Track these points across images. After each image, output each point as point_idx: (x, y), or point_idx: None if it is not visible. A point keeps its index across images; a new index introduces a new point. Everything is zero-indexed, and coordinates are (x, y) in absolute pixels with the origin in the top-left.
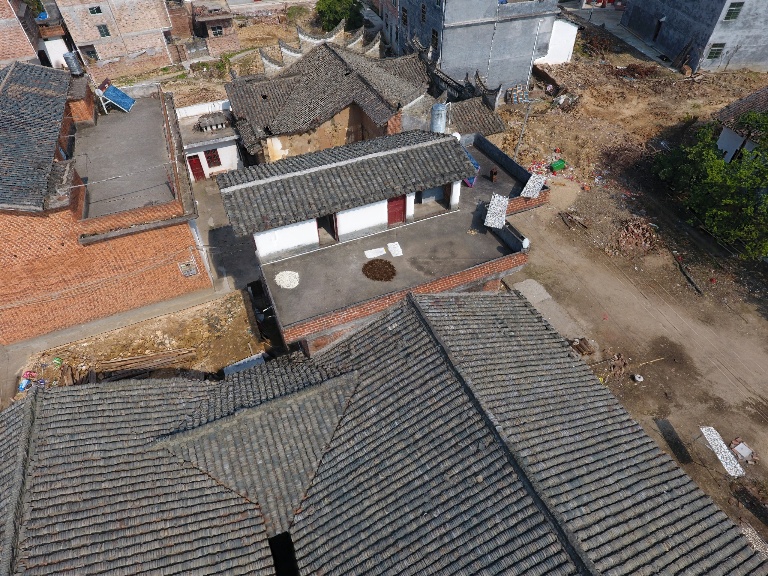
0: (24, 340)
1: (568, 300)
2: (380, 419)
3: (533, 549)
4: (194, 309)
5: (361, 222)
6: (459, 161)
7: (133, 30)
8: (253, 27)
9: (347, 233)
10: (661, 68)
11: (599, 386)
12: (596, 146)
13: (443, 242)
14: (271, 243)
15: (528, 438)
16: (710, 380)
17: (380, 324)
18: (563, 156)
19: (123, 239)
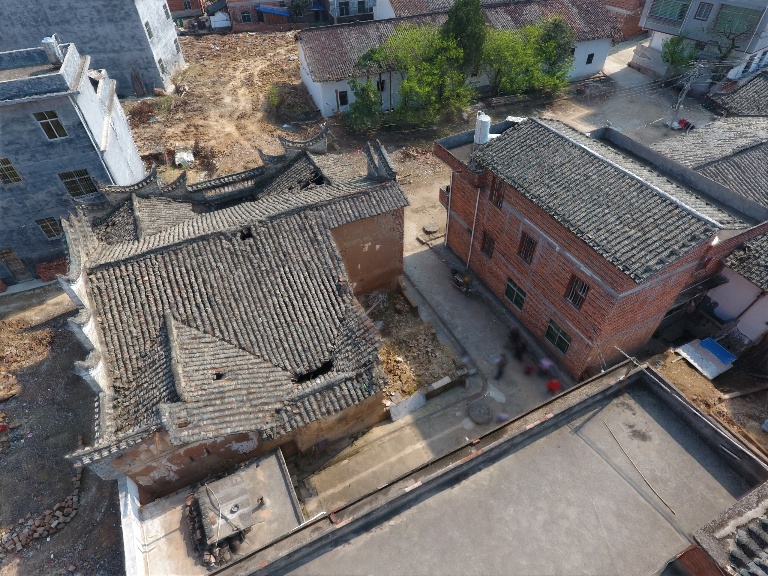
0: None
1: None
2: None
3: None
4: None
5: None
6: None
7: None
8: None
9: None
10: (149, 100)
11: None
12: None
13: None
14: None
15: None
16: None
17: None
18: None
19: None
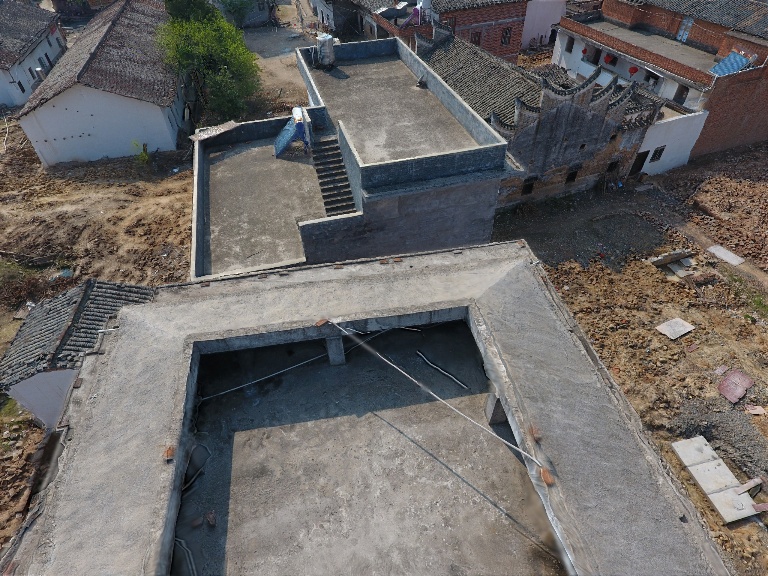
0: None
1: None
2: None
3: None
4: None
5: None
6: None
7: None
8: None
9: None
10: None
11: None
12: None
13: None
14: None
15: None
16: None
17: None
18: None
19: None
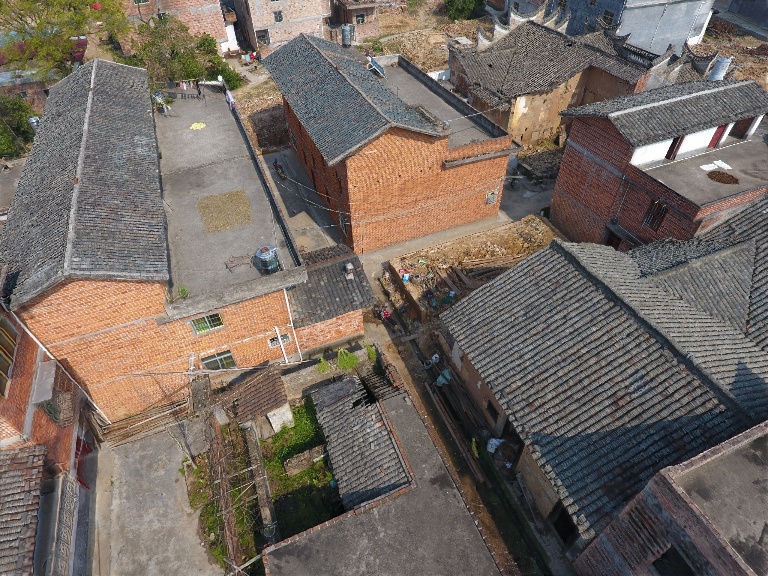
0: (368, 252)
1: None
2: None
3: None
4: (501, 229)
5: (694, 144)
6: (765, 98)
7: (299, 16)
8: (384, 16)
9: (682, 153)
10: None
11: None
12: None
13: (757, 160)
14: (640, 157)
15: None
16: None
17: (751, 210)
18: None
19: (466, 167)
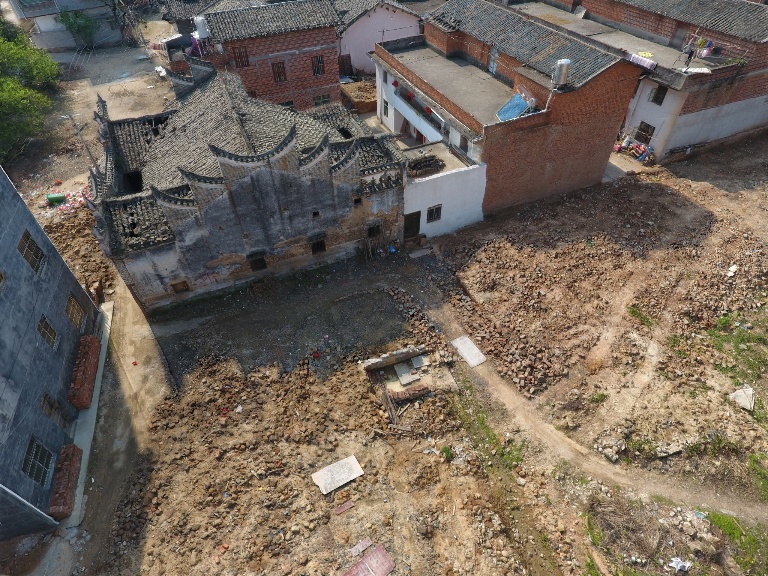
0: None
1: None
2: None
3: (251, 0)
4: None
5: None
6: None
7: None
8: None
9: None
10: None
11: None
12: None
13: None
14: None
15: None
16: None
17: None
18: None
19: None
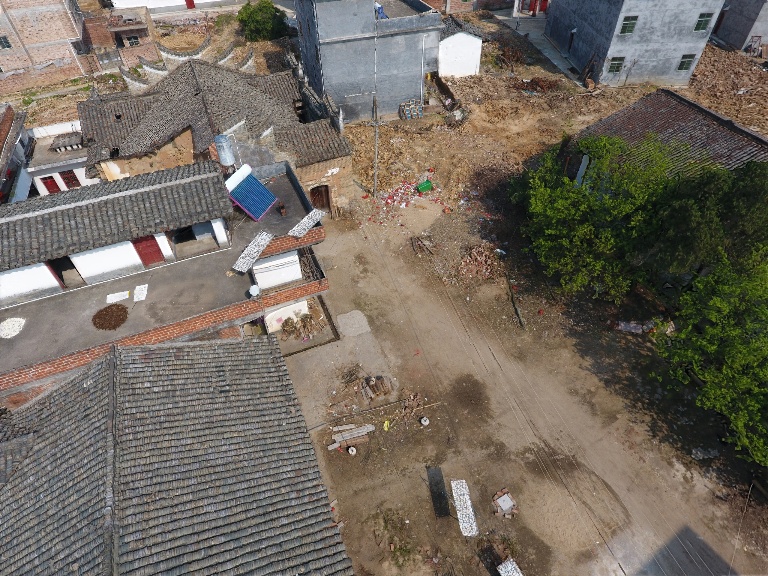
0: None
1: (386, 333)
2: (34, 489)
3: None
4: None
5: (107, 264)
6: (216, 199)
7: (38, 41)
8: (176, 36)
9: (94, 275)
10: (564, 82)
11: (303, 446)
12: (470, 165)
13: (194, 285)
14: None
15: (152, 517)
16: (499, 423)
17: (81, 379)
18: (435, 176)
19: None
